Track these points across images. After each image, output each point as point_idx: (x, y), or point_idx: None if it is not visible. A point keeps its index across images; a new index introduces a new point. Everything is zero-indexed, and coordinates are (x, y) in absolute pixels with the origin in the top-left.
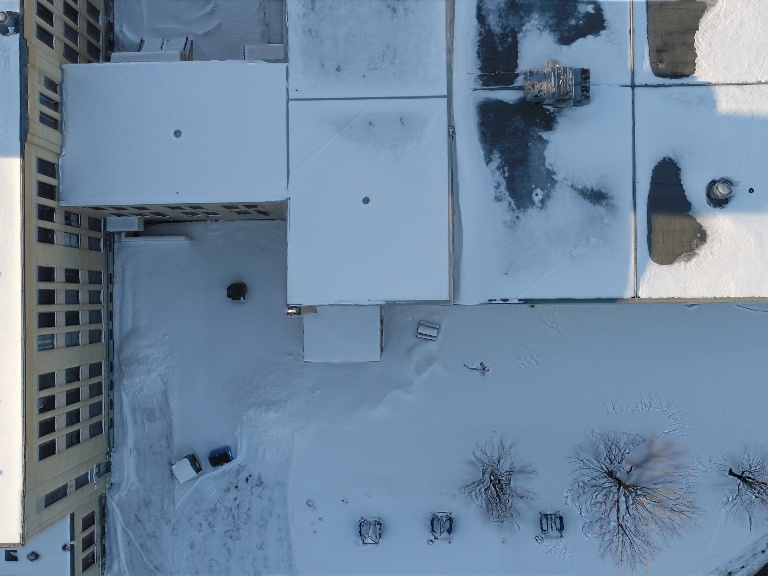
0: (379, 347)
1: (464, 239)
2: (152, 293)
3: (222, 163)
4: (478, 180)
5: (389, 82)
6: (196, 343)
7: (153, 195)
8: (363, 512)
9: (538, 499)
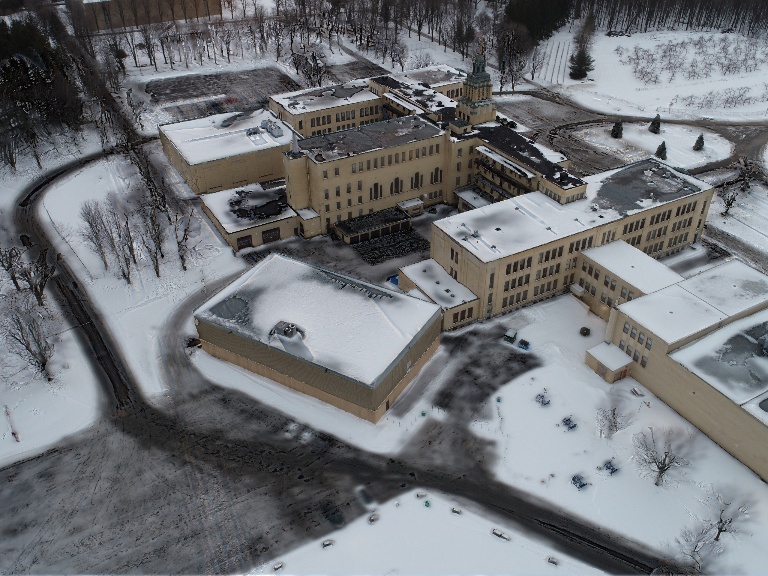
0: (618, 369)
1: (692, 346)
2: (560, 309)
3: (638, 278)
4: (716, 344)
5: (714, 303)
6: (555, 327)
7: None
8: (547, 397)
9: (616, 458)
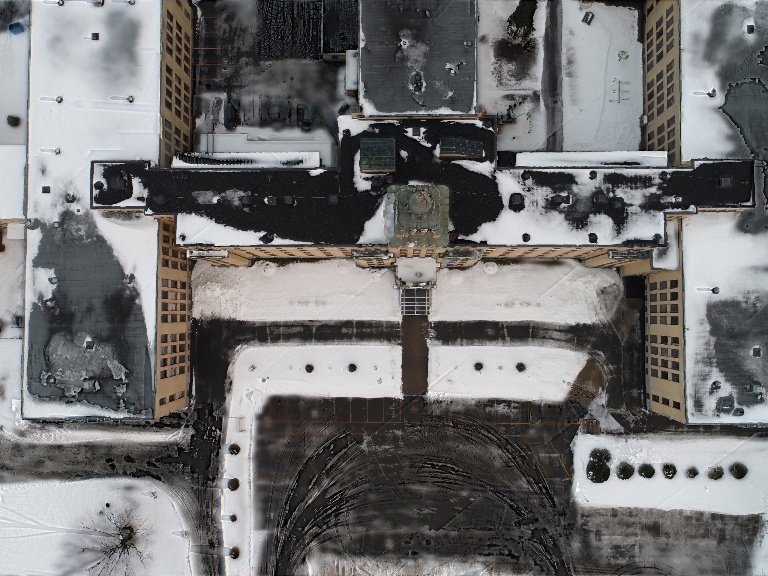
0: None
1: None
2: None
3: None
4: None
5: None
6: None
7: None
8: None
9: None
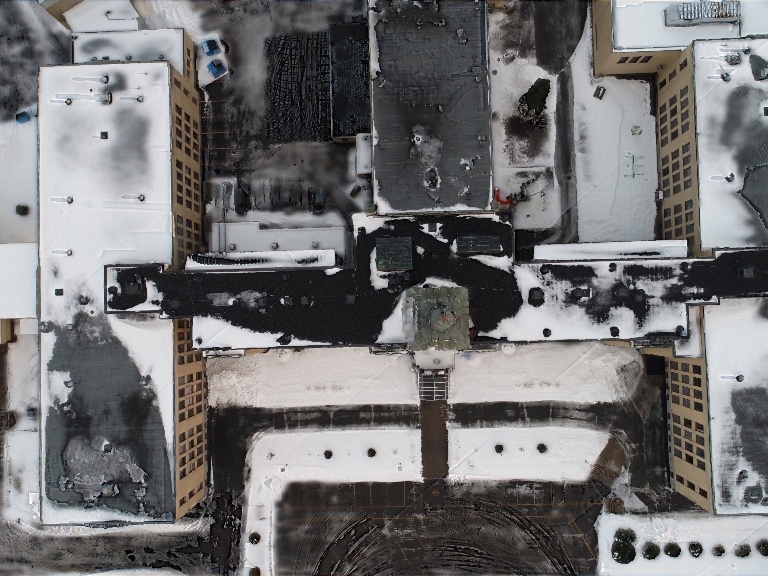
0: None
1: None
2: None
3: None
4: None
5: None
6: None
7: (7, 248)
8: None
9: None
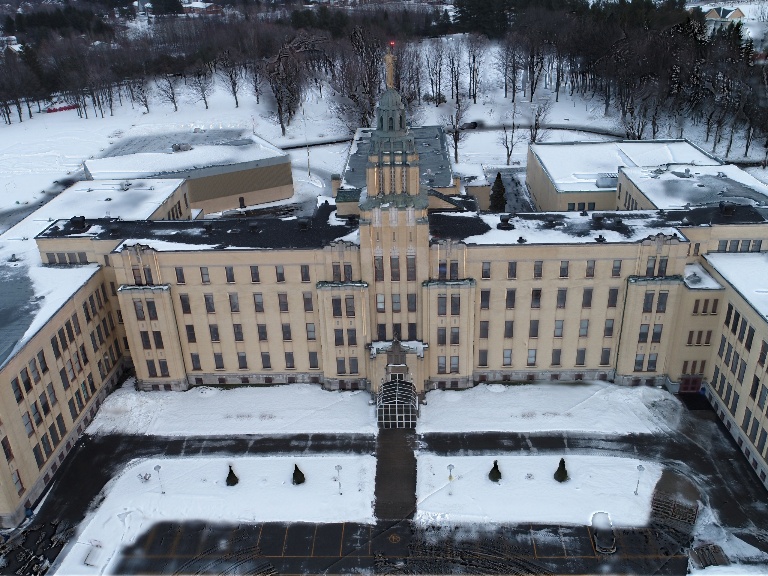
0: None
1: None
2: None
3: None
4: None
5: None
6: None
7: None
8: None
9: None
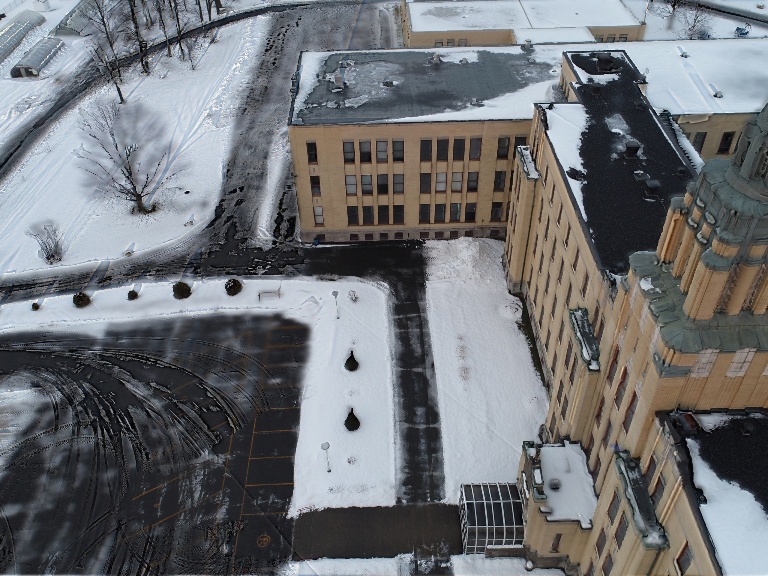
0: None
1: None
2: None
3: None
4: None
5: None
6: None
7: None
8: None
9: None
